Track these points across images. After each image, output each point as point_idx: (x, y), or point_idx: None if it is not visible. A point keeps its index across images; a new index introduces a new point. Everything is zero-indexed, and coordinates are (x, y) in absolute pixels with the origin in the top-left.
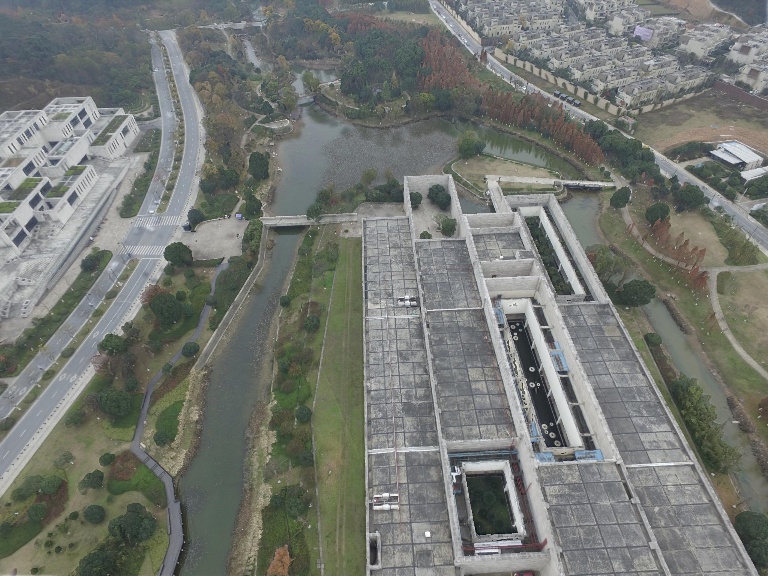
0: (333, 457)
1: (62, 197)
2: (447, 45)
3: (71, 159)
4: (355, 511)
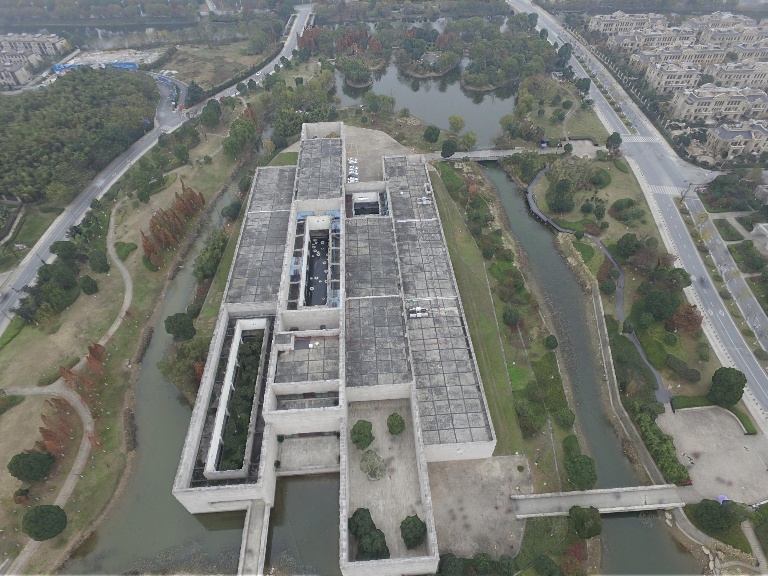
0: (461, 238)
1: None
2: None
3: None
4: (441, 219)
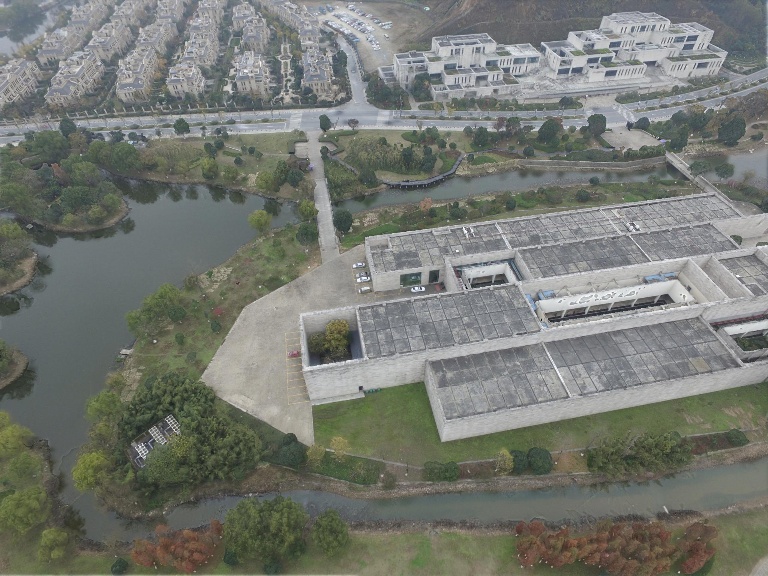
0: None
1: (606, 68)
2: None
3: (643, 55)
4: None
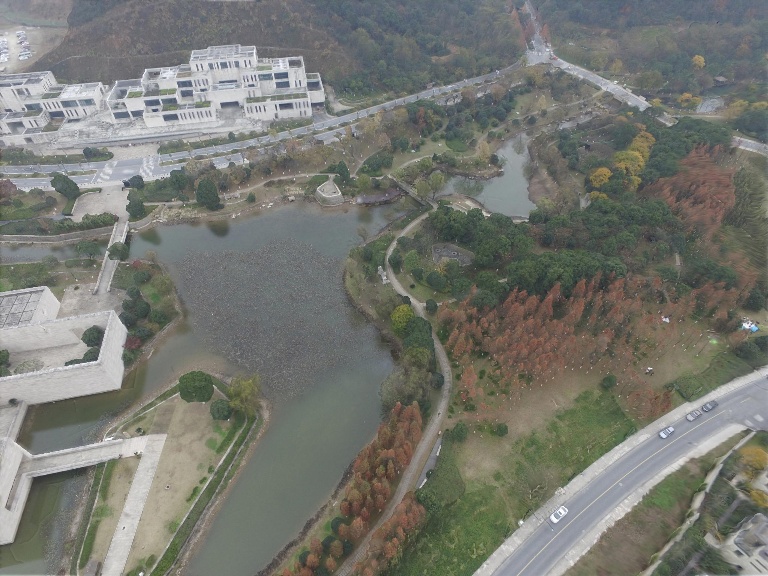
0: None
1: (161, 111)
2: (643, 318)
3: (215, 96)
4: None
